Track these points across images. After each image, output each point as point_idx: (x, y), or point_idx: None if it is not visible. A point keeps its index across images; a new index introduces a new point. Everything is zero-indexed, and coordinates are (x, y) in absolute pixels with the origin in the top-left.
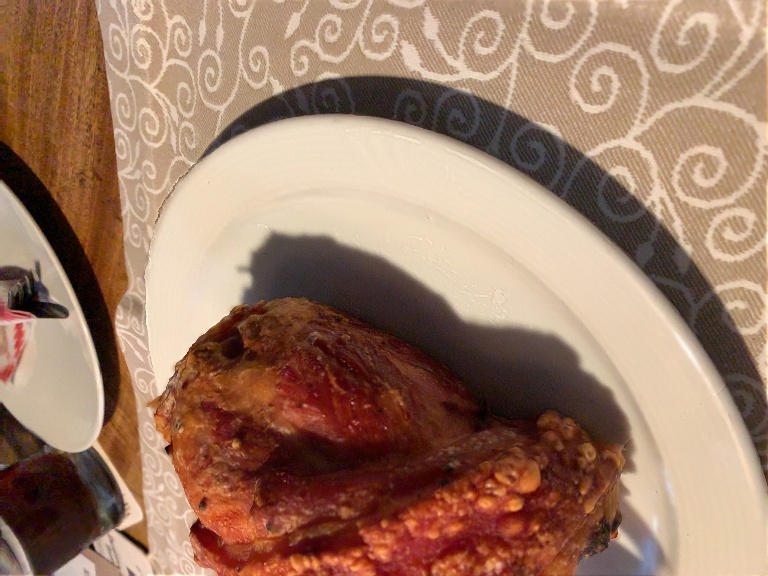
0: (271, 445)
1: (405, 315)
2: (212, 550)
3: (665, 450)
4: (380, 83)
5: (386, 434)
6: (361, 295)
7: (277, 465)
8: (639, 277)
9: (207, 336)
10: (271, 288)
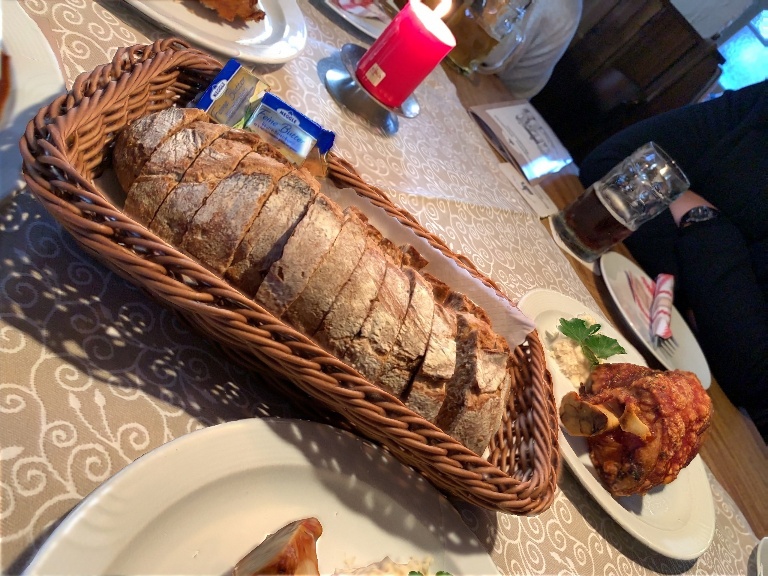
0: None
1: None
2: None
3: None
4: None
5: None
6: None
7: None
8: None
9: None
10: None
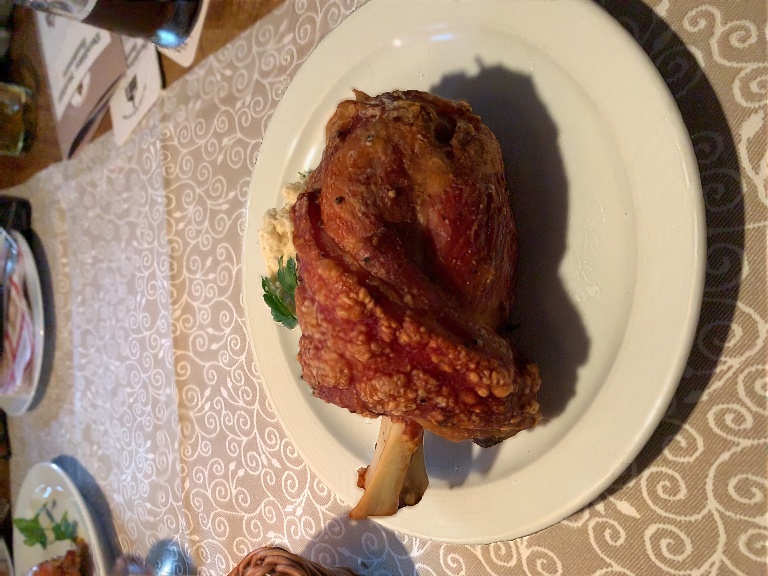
0: (407, 217)
1: (534, 227)
2: (312, 222)
3: (562, 446)
4: (715, 109)
5: (465, 286)
6: (526, 183)
7: (398, 231)
8: (673, 386)
9: (433, 100)
10: (480, 98)
